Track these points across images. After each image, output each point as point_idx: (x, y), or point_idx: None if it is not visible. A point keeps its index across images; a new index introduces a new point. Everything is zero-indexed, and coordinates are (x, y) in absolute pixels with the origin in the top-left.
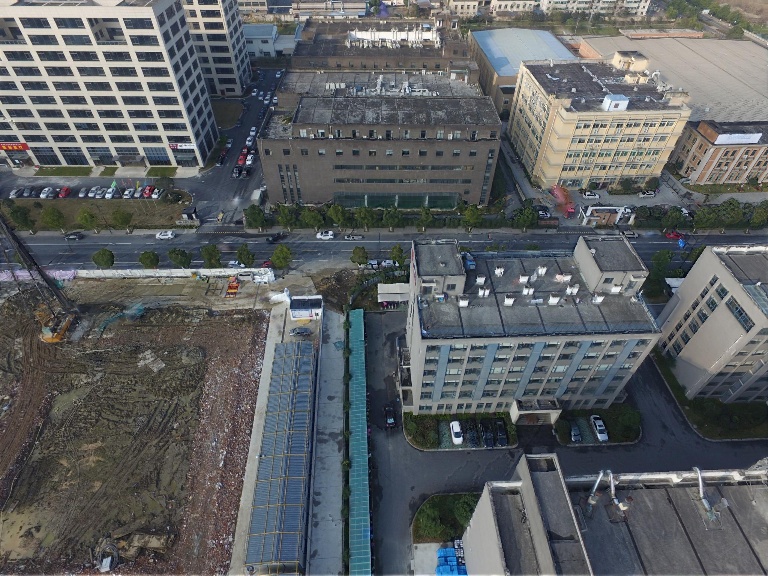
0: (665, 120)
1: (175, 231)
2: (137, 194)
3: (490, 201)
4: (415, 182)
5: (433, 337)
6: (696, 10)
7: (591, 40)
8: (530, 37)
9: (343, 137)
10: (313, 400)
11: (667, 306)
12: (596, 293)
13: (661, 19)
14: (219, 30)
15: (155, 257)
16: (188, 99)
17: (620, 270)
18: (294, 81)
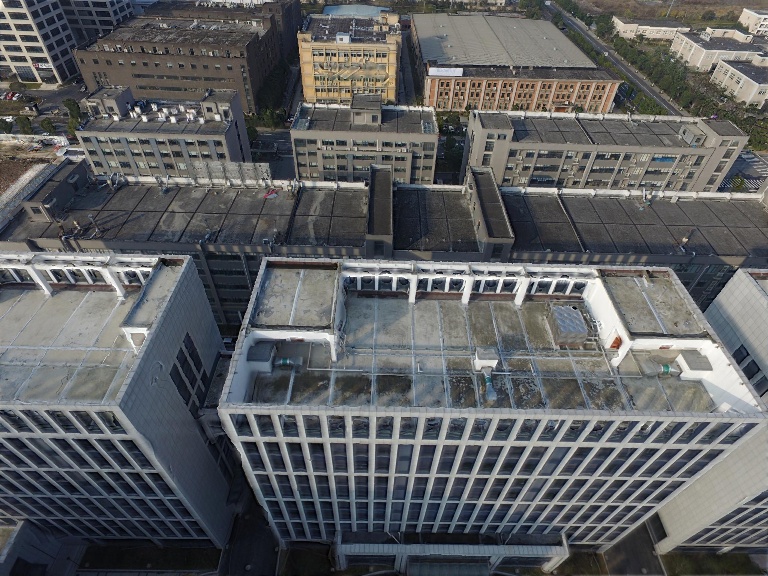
0: (379, 52)
1: None
2: (2, 97)
3: None
4: (196, 91)
5: None
6: (541, 2)
7: (418, 15)
8: (367, 11)
9: None
10: None
11: None
12: None
13: (515, 9)
14: None
15: None
16: (44, 29)
17: None
18: (134, 23)
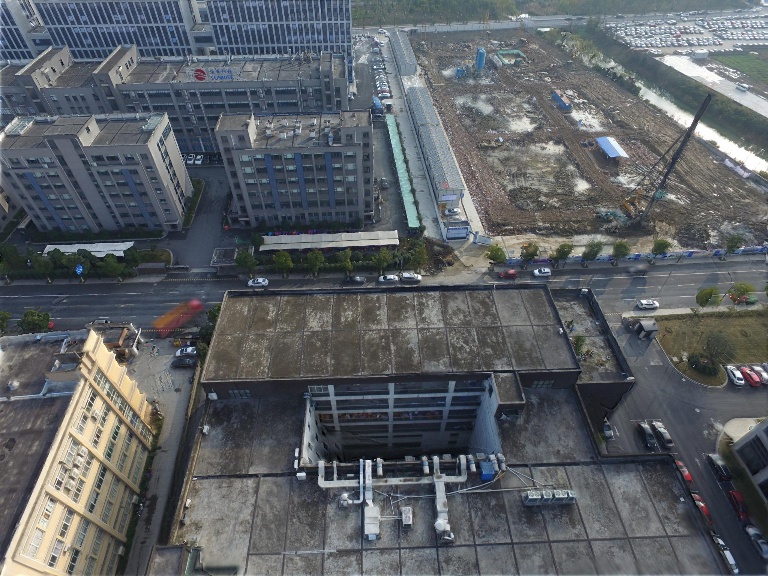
0: None
1: (645, 313)
2: (759, 368)
3: None
4: None
5: None
6: None
7: None
8: None
9: None
10: None
11: None
12: None
13: None
14: None
15: (615, 248)
16: None
17: (238, 115)
18: (681, 547)
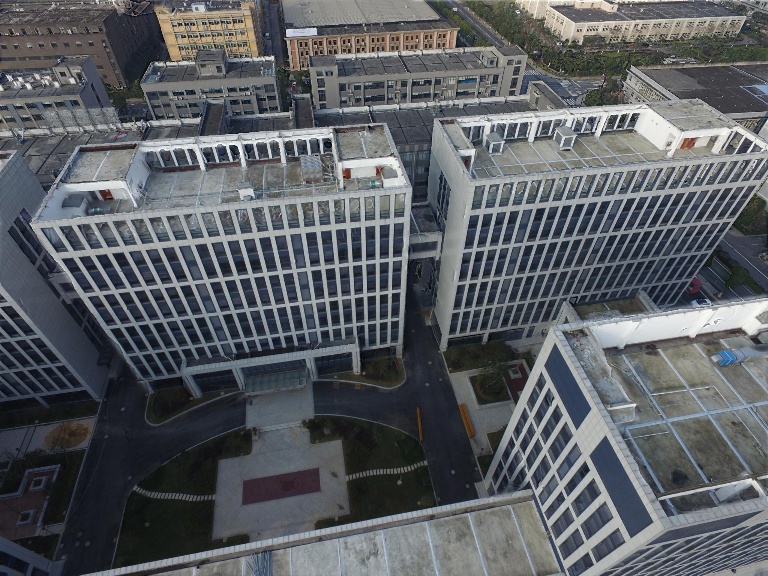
0: (235, 18)
1: None
2: None
3: None
4: None
5: None
6: None
7: None
8: None
9: None
10: None
11: None
12: None
13: None
14: None
15: None
16: None
17: None
18: None
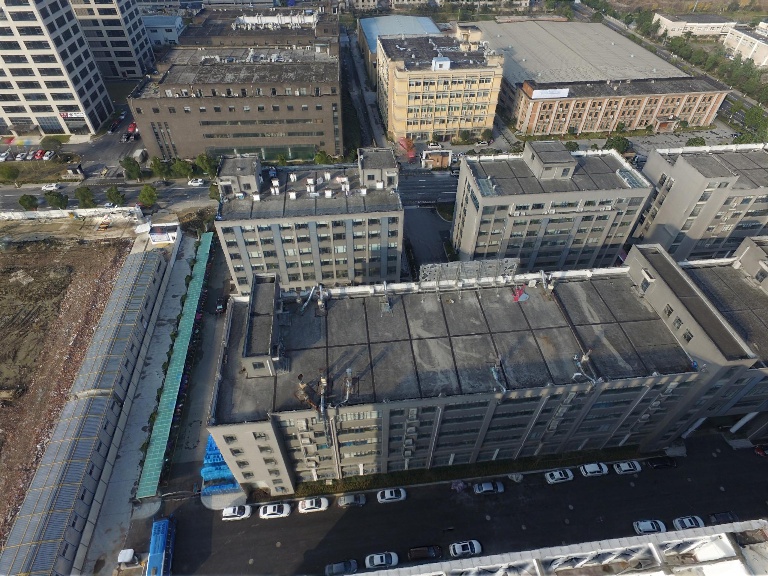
0: (483, 77)
1: (61, 184)
2: (29, 157)
3: (347, 153)
4: (275, 136)
5: (225, 220)
6: (569, 0)
7: (464, 24)
8: (410, 22)
9: (204, 96)
10: (156, 295)
11: (454, 213)
12: (360, 186)
13: (542, 9)
14: (113, 16)
15: (34, 199)
16: (73, 71)
17: (378, 168)
18: (175, 56)
